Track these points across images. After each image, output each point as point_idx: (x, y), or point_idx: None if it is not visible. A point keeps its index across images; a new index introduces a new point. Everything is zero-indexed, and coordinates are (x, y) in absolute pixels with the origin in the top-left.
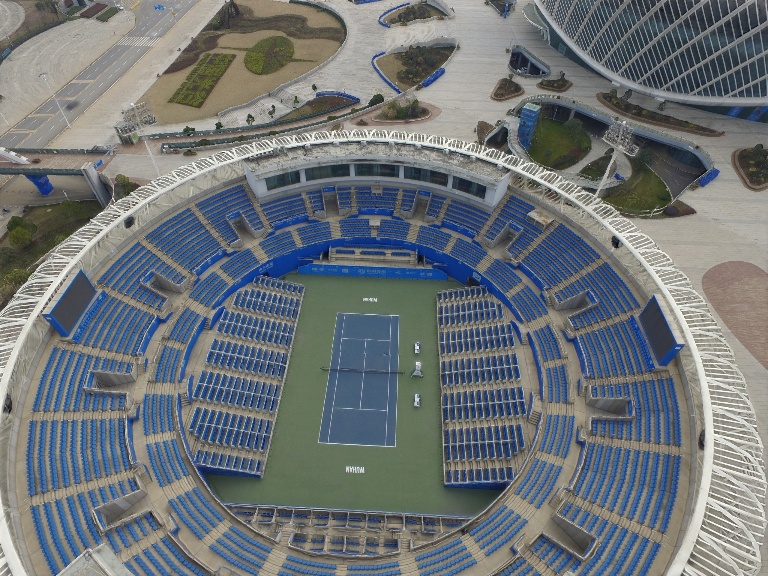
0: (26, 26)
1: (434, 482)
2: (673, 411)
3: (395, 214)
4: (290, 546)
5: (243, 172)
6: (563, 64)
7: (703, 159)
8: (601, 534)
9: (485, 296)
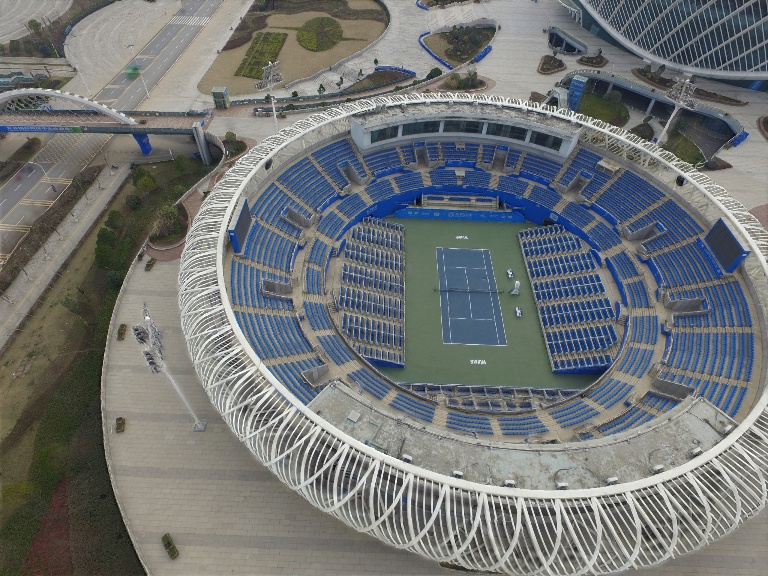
0: (81, 5)
1: (544, 370)
2: (742, 304)
3: (478, 166)
4: (450, 405)
5: (347, 128)
6: (597, 44)
7: (732, 124)
8: (697, 387)
9: (562, 233)
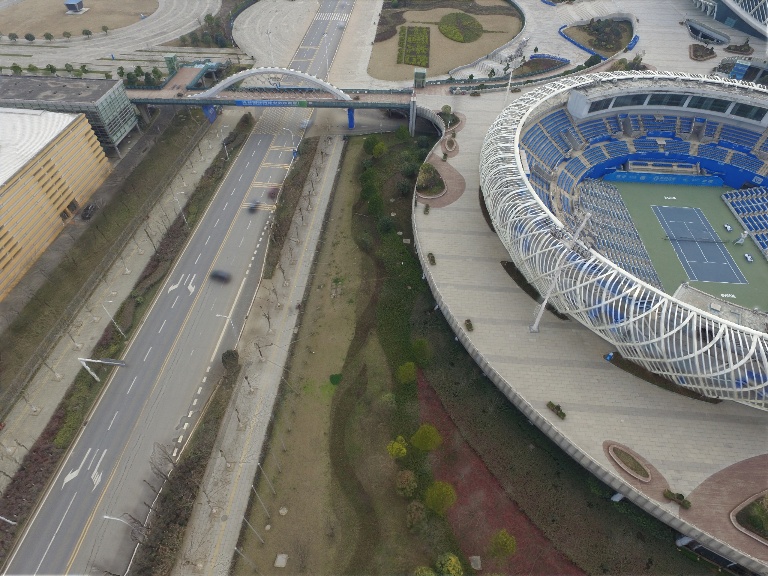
0: (235, 3)
1: None
2: None
3: (677, 136)
4: None
5: (563, 100)
6: (736, 34)
7: None
8: None
9: (767, 194)
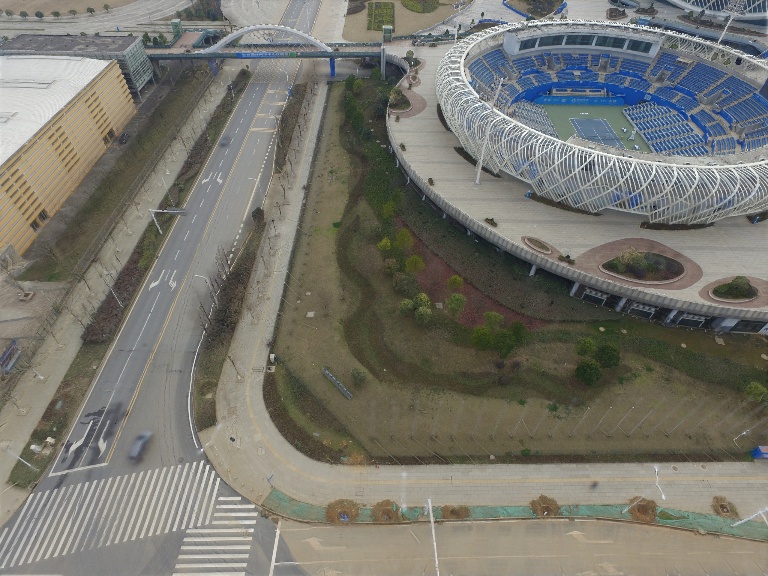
0: None
1: None
2: None
3: (589, 68)
4: None
5: (500, 42)
6: (645, 1)
7: (760, 47)
8: None
9: None
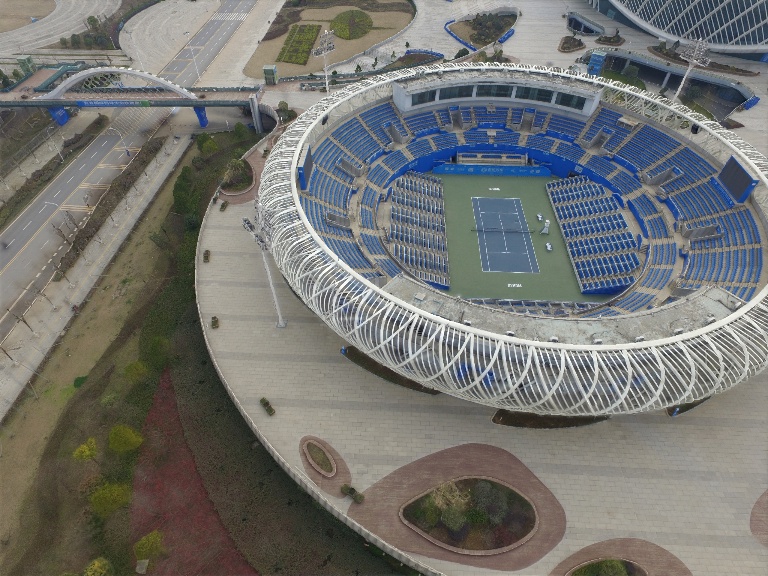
0: None
1: (574, 292)
2: (752, 226)
3: (507, 127)
4: None
5: (389, 93)
6: (614, 26)
7: (744, 92)
8: None
9: (587, 183)
